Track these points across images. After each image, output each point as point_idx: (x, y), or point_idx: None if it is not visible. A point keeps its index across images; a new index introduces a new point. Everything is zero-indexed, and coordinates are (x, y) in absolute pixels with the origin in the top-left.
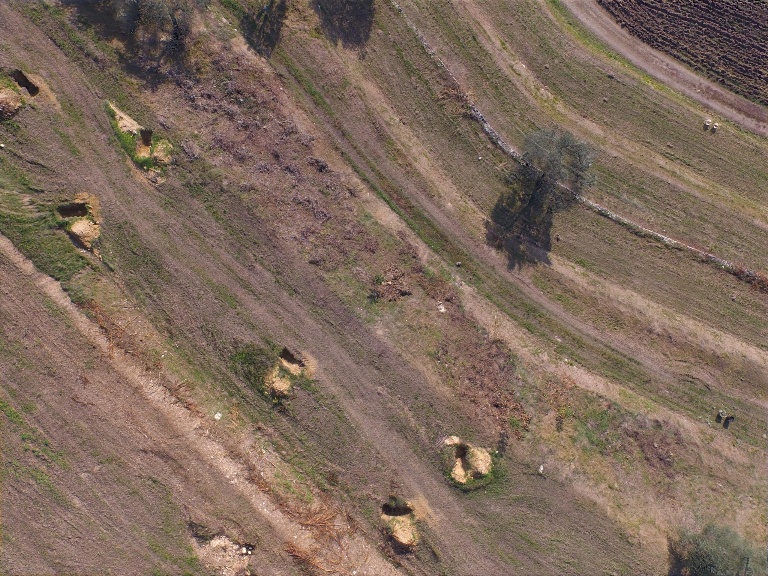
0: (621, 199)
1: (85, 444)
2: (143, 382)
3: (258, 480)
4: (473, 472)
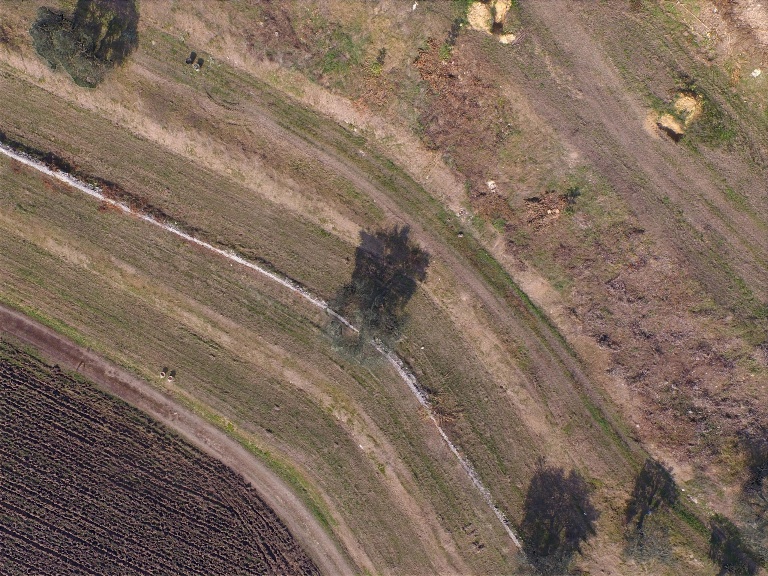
0: (274, 300)
1: None
2: None
3: (723, 3)
4: (489, 5)
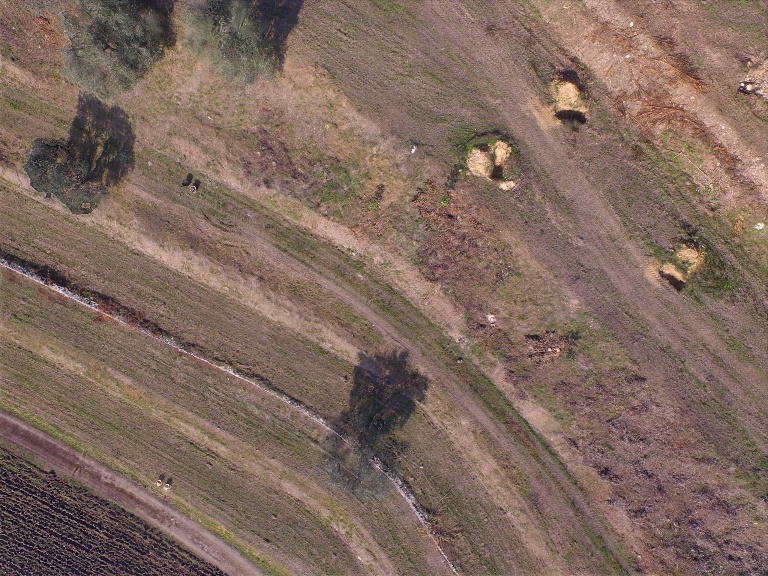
0: (272, 414)
1: None
2: None
3: (726, 158)
4: (489, 152)
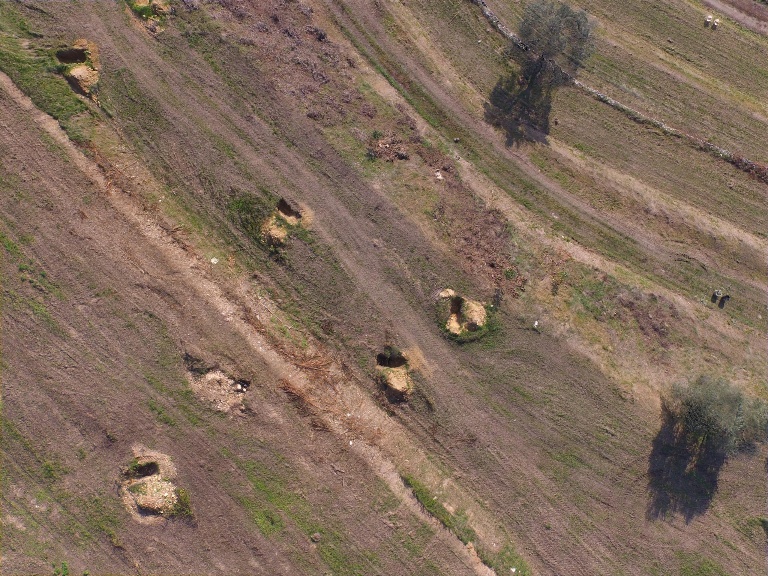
0: (620, 88)
1: (82, 277)
2: (140, 220)
3: (254, 321)
4: (468, 324)
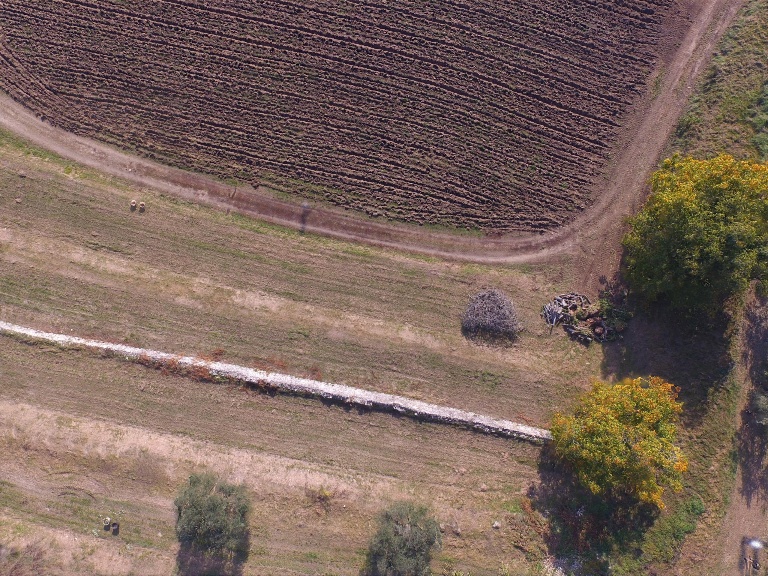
0: (21, 306)
1: None
2: None
3: None
4: None
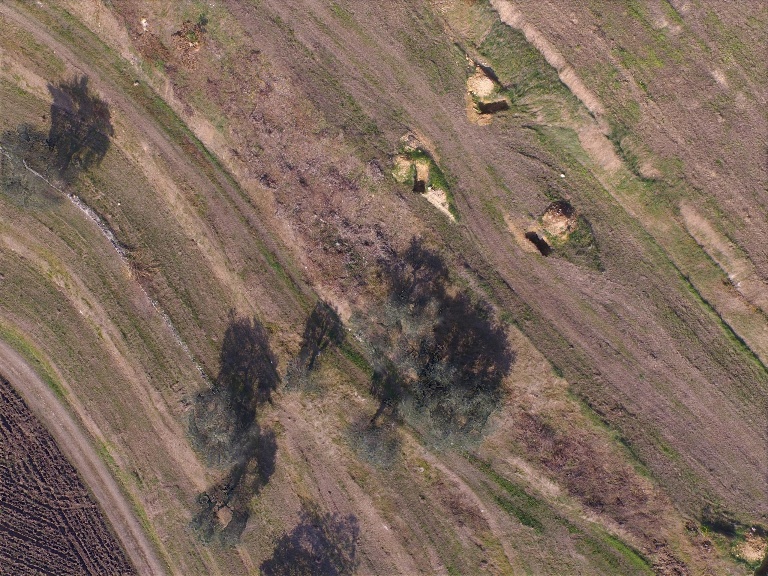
0: None
1: None
2: None
3: None
4: None
